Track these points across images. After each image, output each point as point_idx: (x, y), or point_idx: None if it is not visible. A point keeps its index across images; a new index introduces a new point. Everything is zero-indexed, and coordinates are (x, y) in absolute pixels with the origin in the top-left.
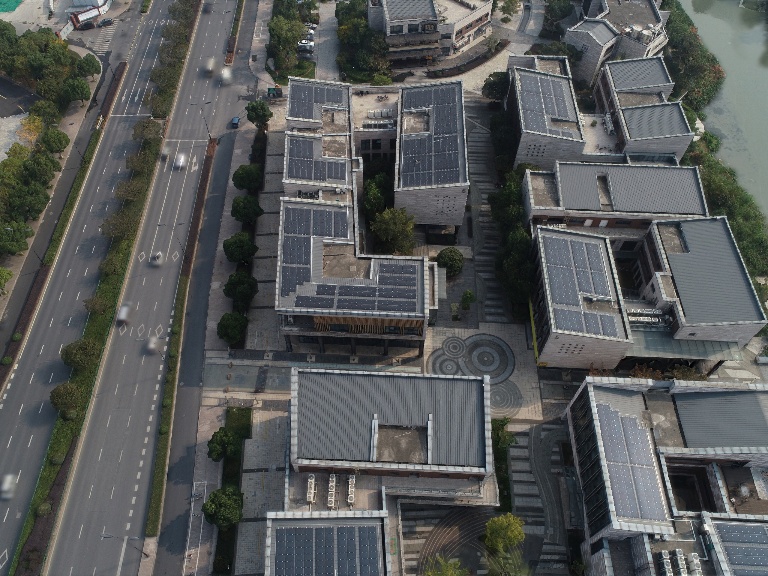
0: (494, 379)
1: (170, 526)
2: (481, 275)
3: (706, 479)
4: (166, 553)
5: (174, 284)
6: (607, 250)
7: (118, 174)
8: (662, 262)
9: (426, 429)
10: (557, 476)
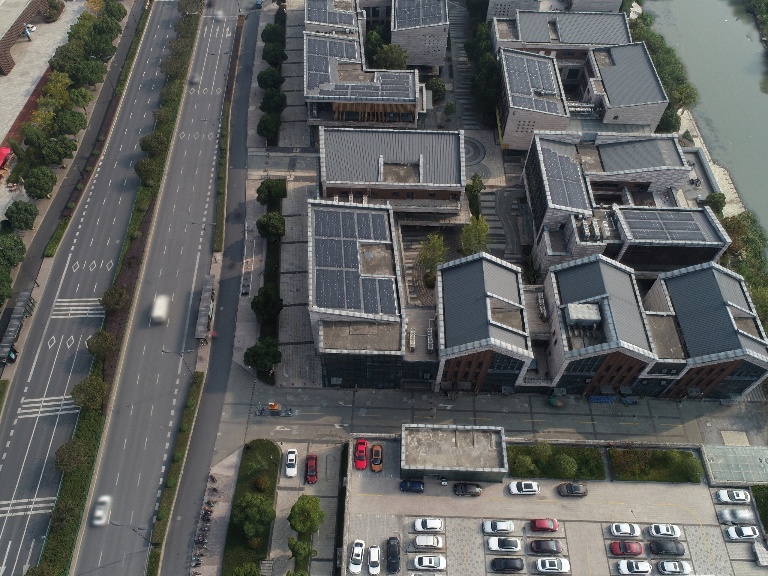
0: (469, 162)
1: (231, 247)
2: (460, 101)
3: (621, 202)
4: (229, 261)
5: (219, 108)
6: (554, 66)
7: (167, 39)
8: (595, 73)
9: (418, 165)
10: (516, 217)
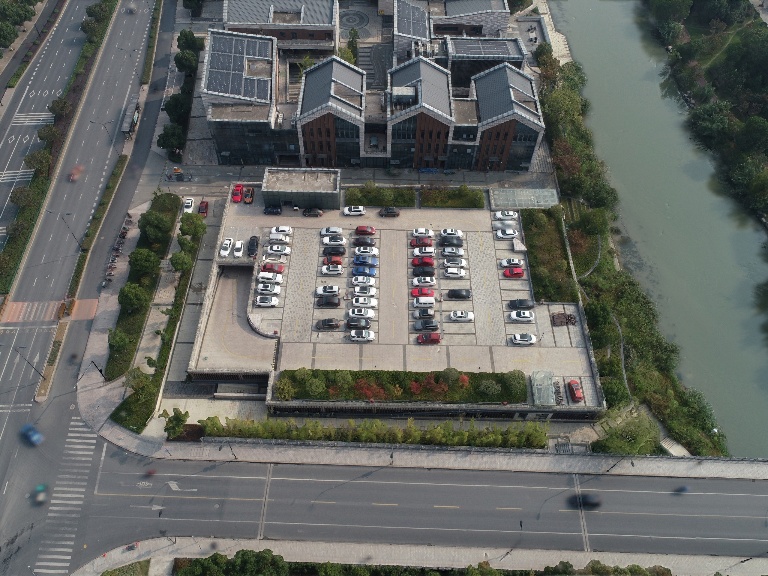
0: (355, 28)
1: (156, 81)
2: None
3: None
4: (154, 90)
5: None
6: None
7: None
8: None
9: None
10: None
